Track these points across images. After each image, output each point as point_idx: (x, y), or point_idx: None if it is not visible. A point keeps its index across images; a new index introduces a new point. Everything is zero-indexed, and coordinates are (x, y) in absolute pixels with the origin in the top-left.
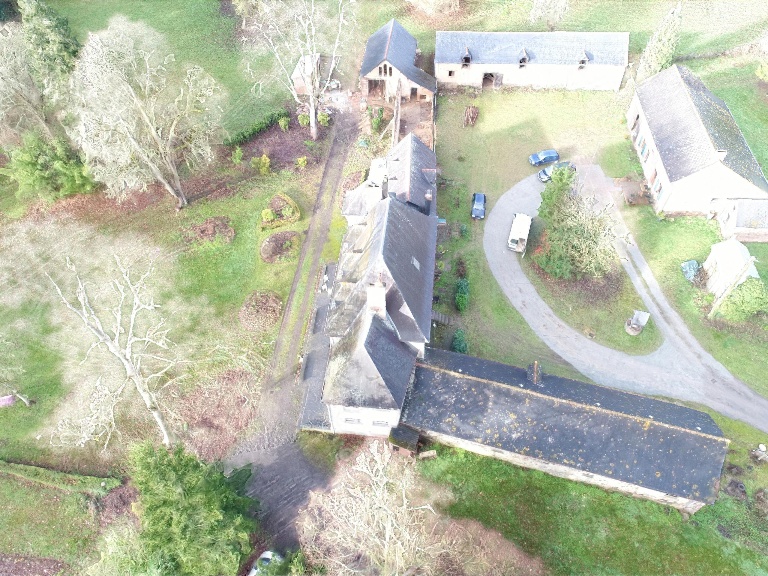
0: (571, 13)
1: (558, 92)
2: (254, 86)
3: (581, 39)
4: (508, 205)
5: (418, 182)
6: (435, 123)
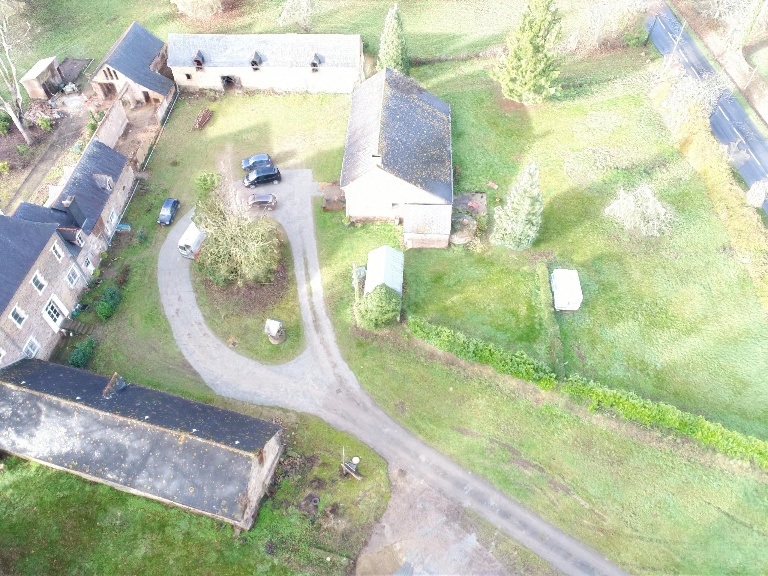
0: (344, 15)
1: (299, 95)
2: None
3: (312, 41)
4: None
5: (80, 188)
6: (164, 127)
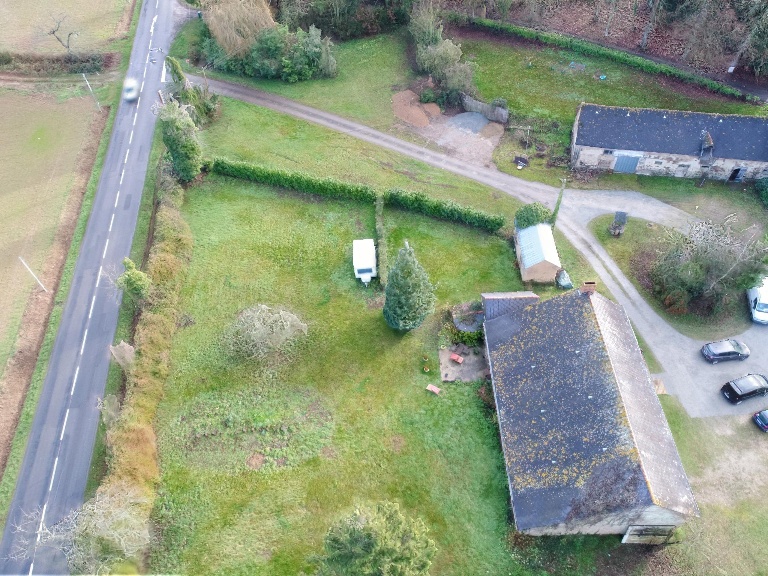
0: None
1: None
2: None
3: None
4: None
5: None
6: None
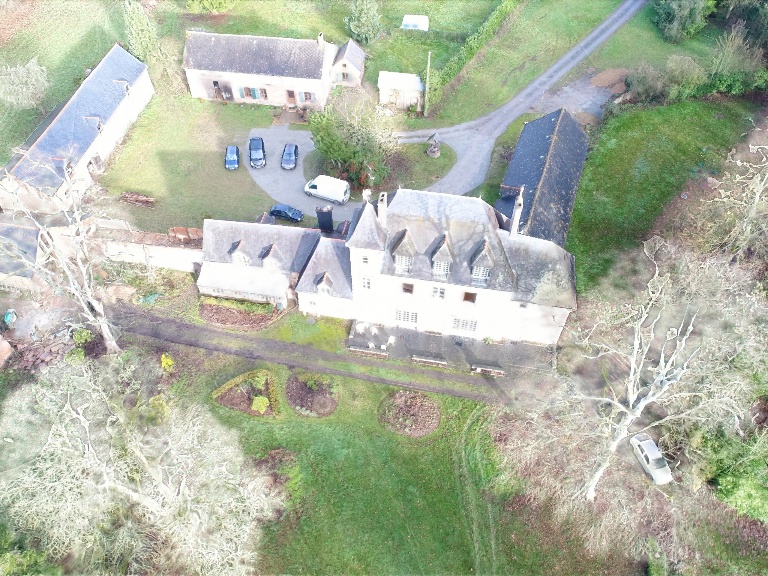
0: None
1: (135, 129)
2: (105, 331)
3: (102, 75)
4: (286, 196)
5: None
6: None
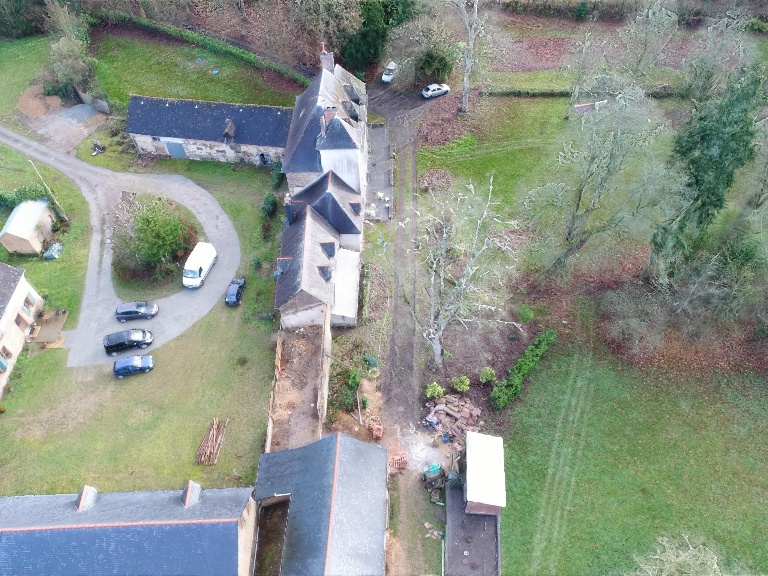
0: None
1: None
2: None
3: None
4: (202, 304)
5: None
6: None
